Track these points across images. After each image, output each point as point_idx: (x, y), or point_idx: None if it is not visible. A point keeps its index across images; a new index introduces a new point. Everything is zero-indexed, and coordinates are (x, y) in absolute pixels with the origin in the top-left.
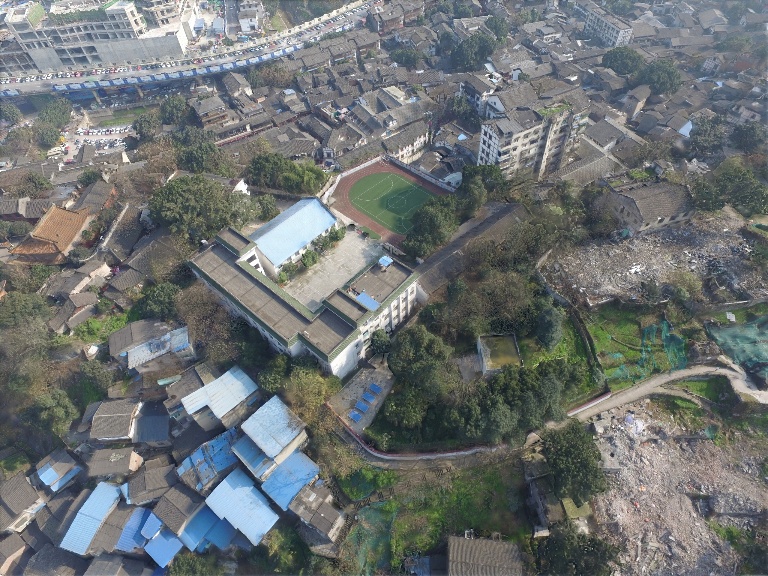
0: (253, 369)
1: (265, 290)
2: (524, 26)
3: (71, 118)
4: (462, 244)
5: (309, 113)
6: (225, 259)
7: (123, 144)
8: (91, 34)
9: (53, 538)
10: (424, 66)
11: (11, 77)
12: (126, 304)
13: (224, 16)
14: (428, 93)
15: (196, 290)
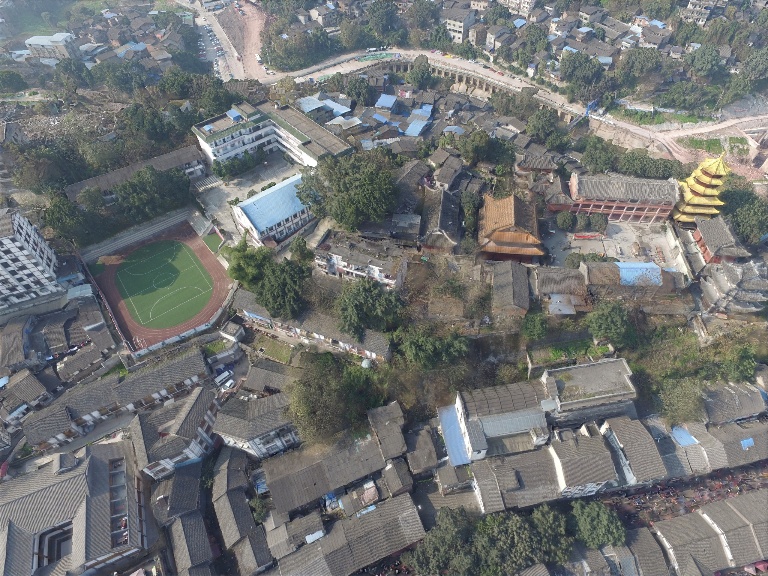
0: None
1: None
2: None
3: None
4: (145, 163)
5: None
6: None
7: None
8: None
9: None
10: None
11: None
12: None
13: None
14: None
15: None
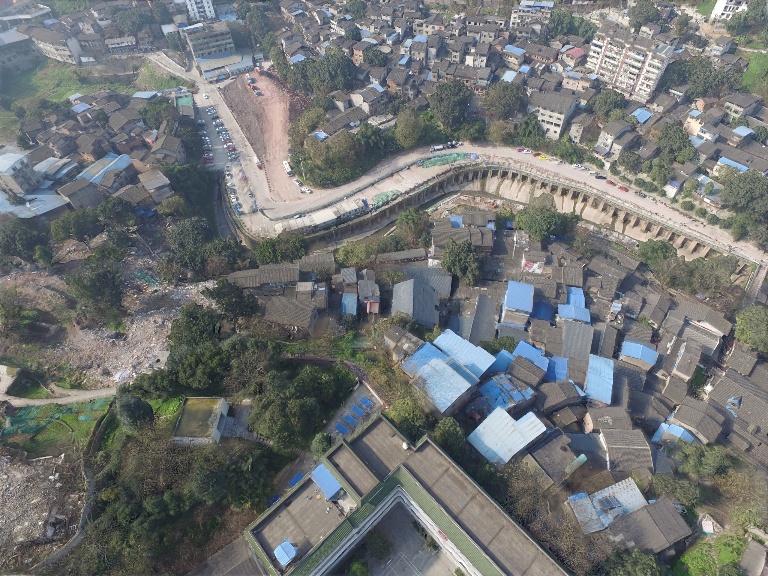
0: None
1: (470, 533)
2: None
3: None
4: None
5: None
6: None
7: None
8: None
9: (638, 392)
10: None
11: None
12: None
13: None
14: None
15: None
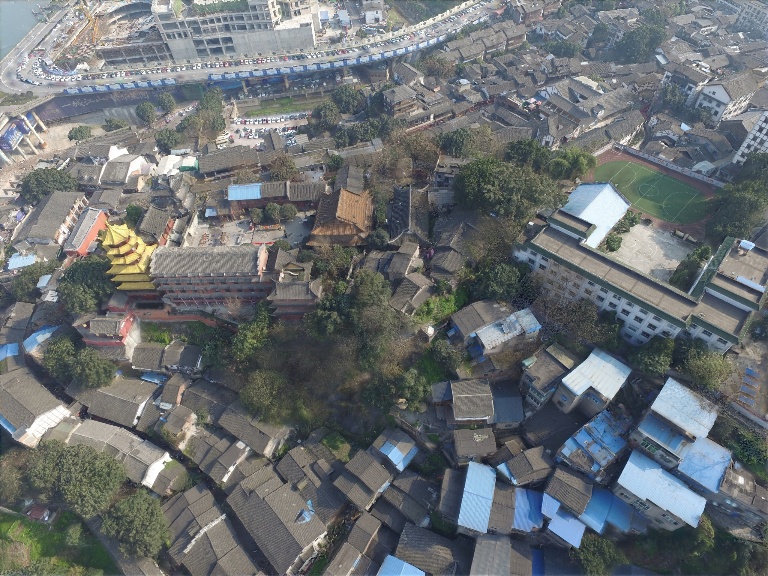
0: (614, 352)
1: (626, 272)
2: (674, 18)
3: (222, 107)
4: None
5: (484, 103)
6: (563, 241)
7: (288, 133)
8: (229, 25)
9: (413, 517)
10: (583, 58)
11: (160, 66)
12: (455, 285)
13: (343, 9)
14: (610, 84)
15: (529, 272)
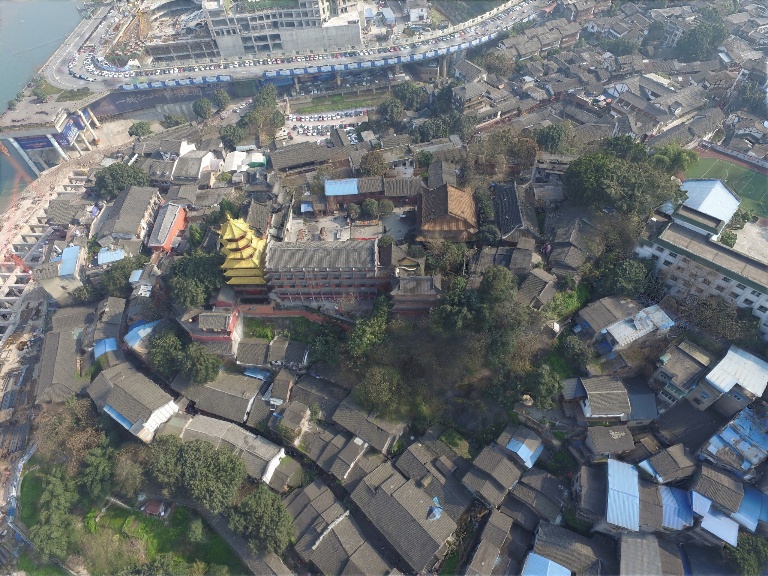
0: (751, 349)
1: (763, 268)
2: (728, 17)
3: None
4: None
5: (548, 101)
6: (690, 237)
7: (347, 130)
8: (277, 22)
9: (547, 515)
10: (642, 56)
11: (212, 63)
12: None
13: (385, 6)
14: (677, 82)
15: (654, 268)
